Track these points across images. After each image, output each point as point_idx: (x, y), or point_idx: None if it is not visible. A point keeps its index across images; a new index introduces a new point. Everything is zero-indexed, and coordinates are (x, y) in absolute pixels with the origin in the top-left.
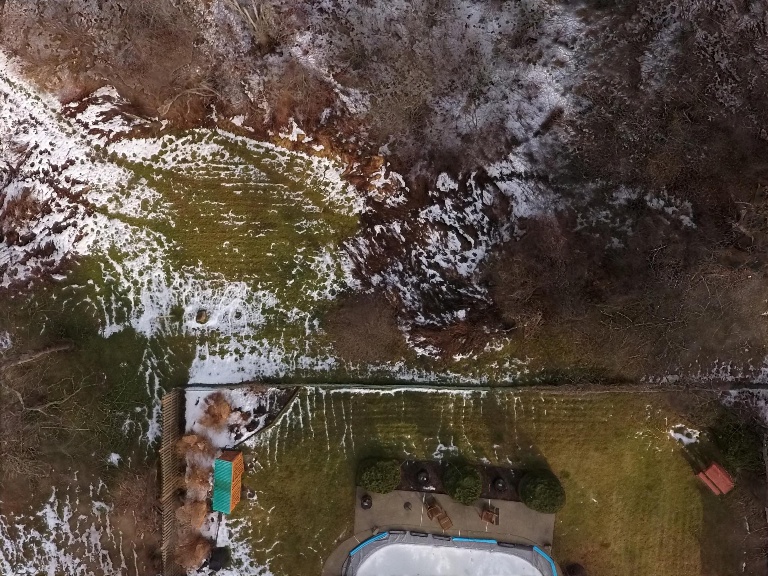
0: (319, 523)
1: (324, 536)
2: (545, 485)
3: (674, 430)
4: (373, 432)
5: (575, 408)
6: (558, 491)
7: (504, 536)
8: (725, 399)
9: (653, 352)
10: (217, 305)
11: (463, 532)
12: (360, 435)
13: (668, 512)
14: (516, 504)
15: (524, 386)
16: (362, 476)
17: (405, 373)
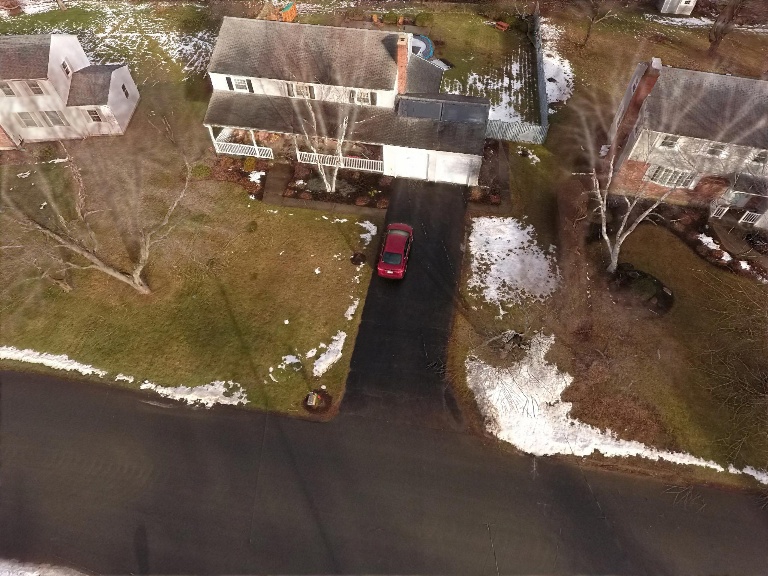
0: None
1: None
2: None
3: None
4: None
5: None
6: None
7: None
8: None
9: (475, 9)
10: (297, 6)
11: None
12: None
13: (483, 35)
14: (413, 26)
15: None
16: None
17: None
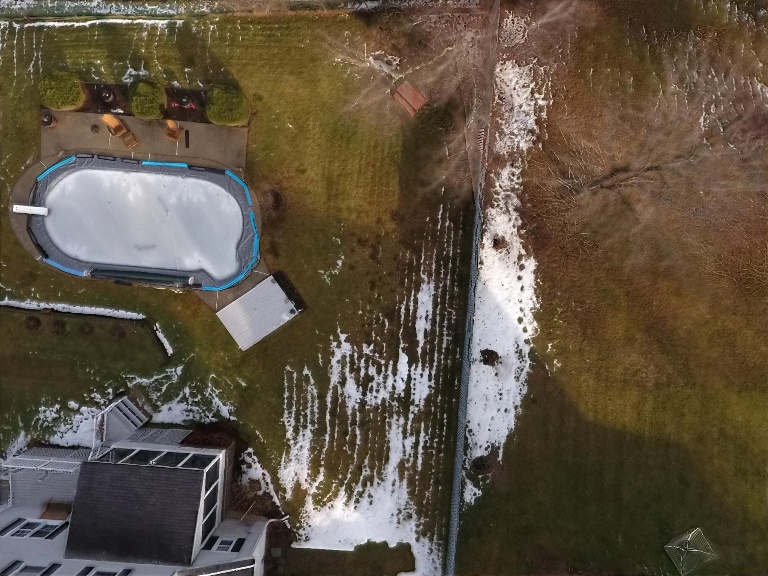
0: (5, 149)
1: (11, 163)
2: (222, 89)
3: (373, 57)
4: (62, 58)
5: (271, 34)
6: (234, 94)
7: (195, 160)
8: (425, 24)
9: None
10: None
11: (153, 156)
12: (48, 61)
13: (367, 139)
14: (206, 126)
15: (219, 13)
16: (37, 87)
17: (102, 7)
